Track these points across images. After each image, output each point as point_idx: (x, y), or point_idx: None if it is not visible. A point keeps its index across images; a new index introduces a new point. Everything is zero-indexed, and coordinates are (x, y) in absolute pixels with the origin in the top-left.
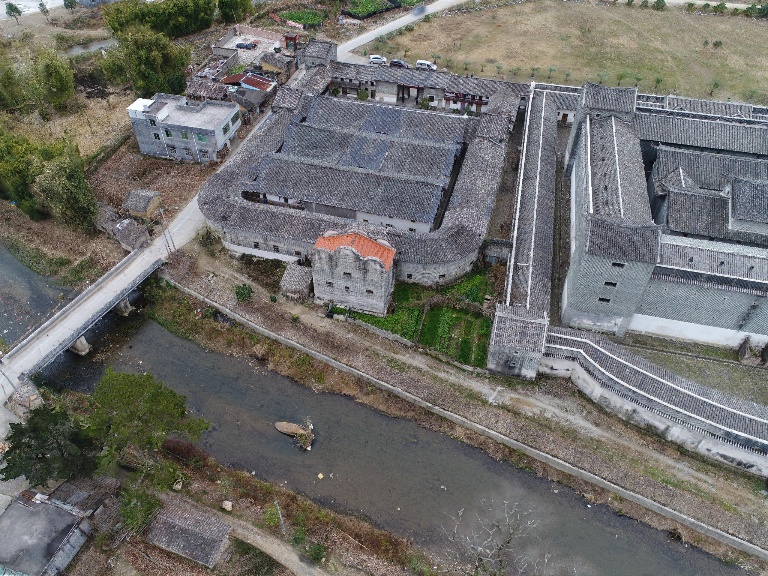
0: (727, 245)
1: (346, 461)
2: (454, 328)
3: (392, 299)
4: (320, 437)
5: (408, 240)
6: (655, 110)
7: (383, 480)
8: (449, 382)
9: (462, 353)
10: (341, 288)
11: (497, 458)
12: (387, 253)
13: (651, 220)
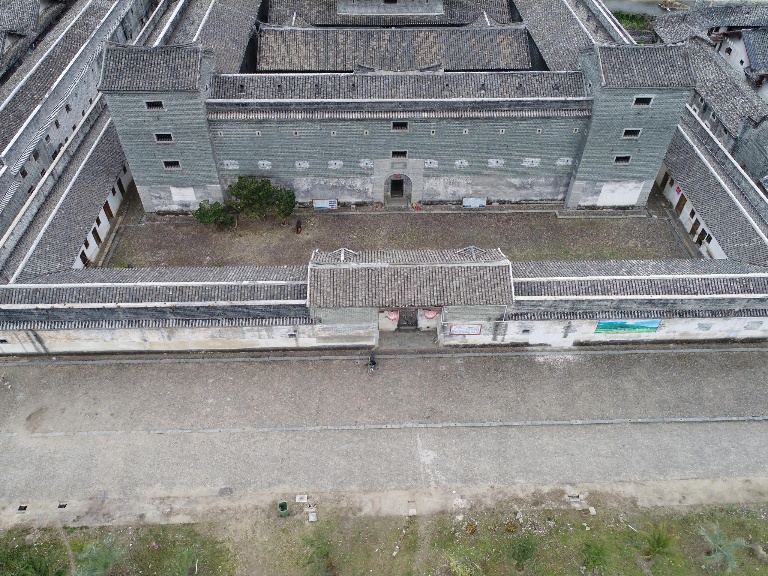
0: None
1: (634, 4)
2: None
3: None
4: (659, 8)
5: None
6: (544, 101)
7: (608, 1)
8: None
9: None
10: None
11: None
12: None
13: None
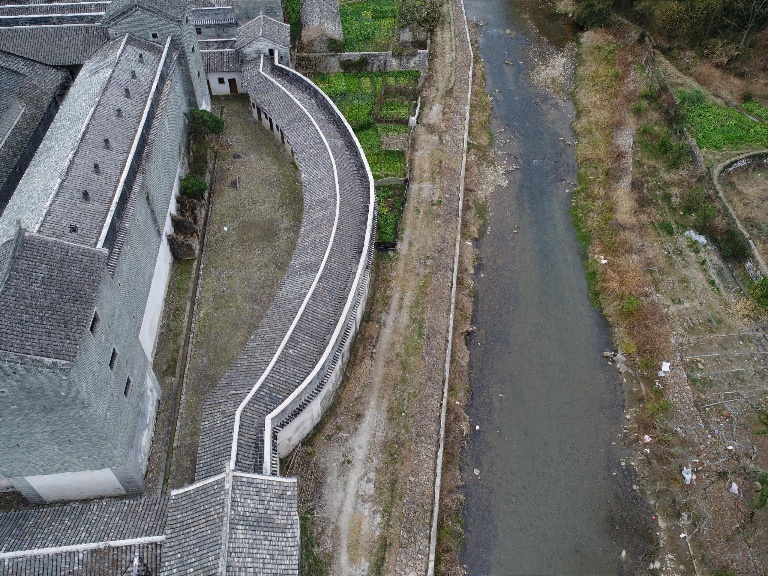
0: (21, 196)
1: None
2: None
3: None
4: None
5: None
6: None
7: None
8: None
9: None
10: None
11: (463, 574)
12: None
13: None
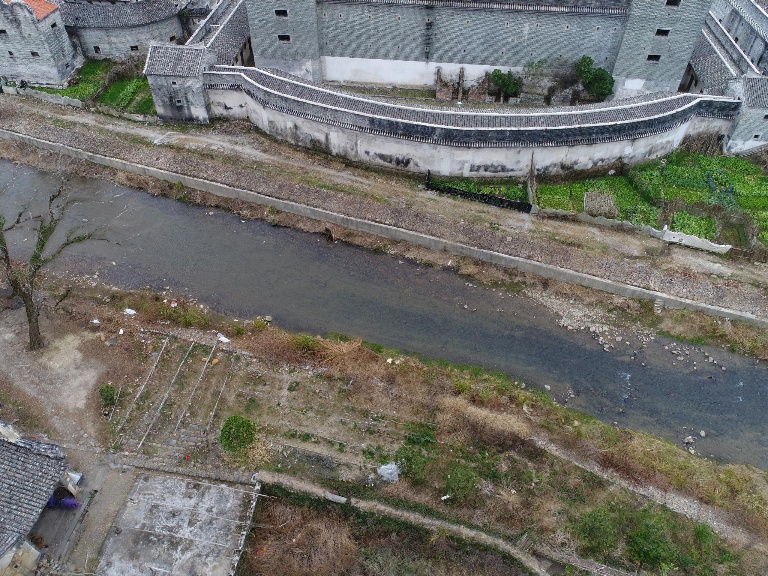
0: None
1: None
2: (140, 93)
3: (77, 73)
4: None
5: (87, 6)
6: None
7: None
8: (115, 131)
9: (139, 109)
10: (5, 55)
11: (155, 193)
12: (46, 6)
13: None
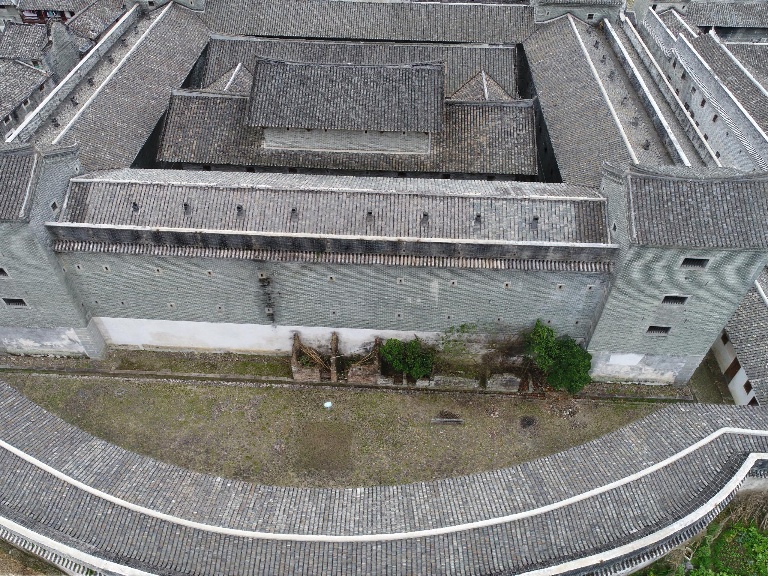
0: (239, 175)
1: None
2: None
3: None
4: None
5: None
6: None
7: None
8: None
9: None
10: None
11: None
12: None
13: (138, 148)
